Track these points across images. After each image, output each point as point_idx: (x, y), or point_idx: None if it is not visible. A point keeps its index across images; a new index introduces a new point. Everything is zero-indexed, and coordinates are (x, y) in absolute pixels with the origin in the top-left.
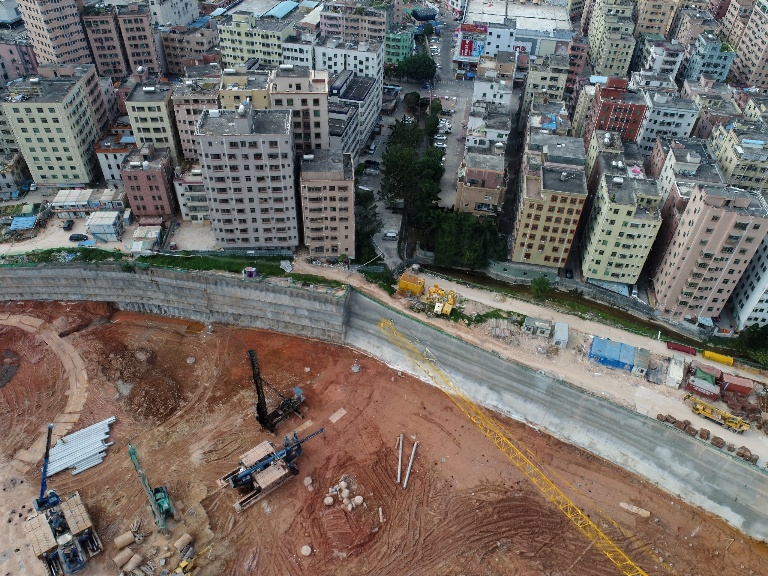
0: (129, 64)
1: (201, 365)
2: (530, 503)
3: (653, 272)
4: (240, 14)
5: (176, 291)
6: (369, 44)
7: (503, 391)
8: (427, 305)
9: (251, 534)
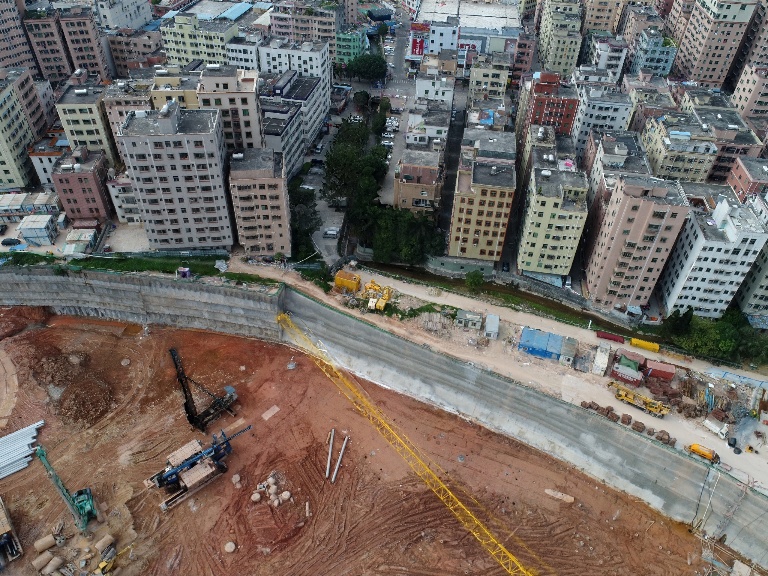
0: (74, 68)
1: (135, 367)
2: (457, 493)
3: (586, 263)
4: (182, 16)
5: (111, 293)
6: (314, 44)
7: (435, 384)
8: (361, 301)
9: (175, 533)
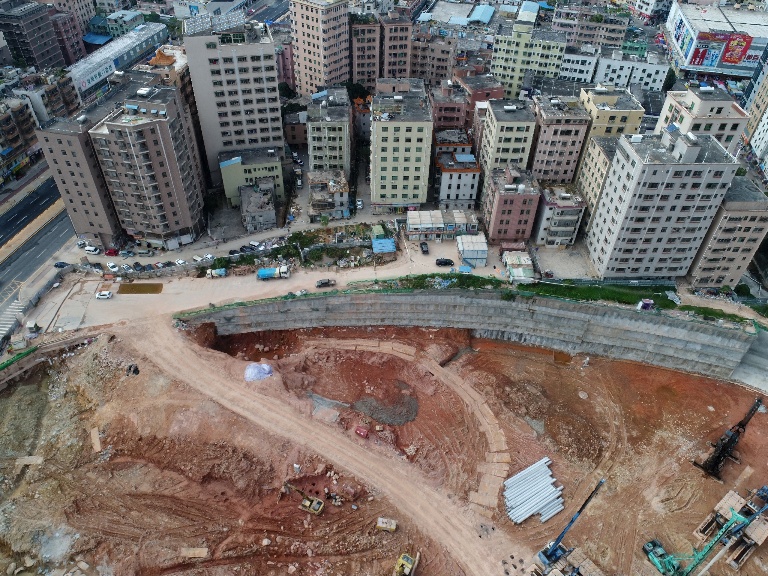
0: (381, 73)
1: (597, 401)
2: None
3: None
4: (523, 24)
5: (552, 320)
6: None
7: None
8: None
9: None
